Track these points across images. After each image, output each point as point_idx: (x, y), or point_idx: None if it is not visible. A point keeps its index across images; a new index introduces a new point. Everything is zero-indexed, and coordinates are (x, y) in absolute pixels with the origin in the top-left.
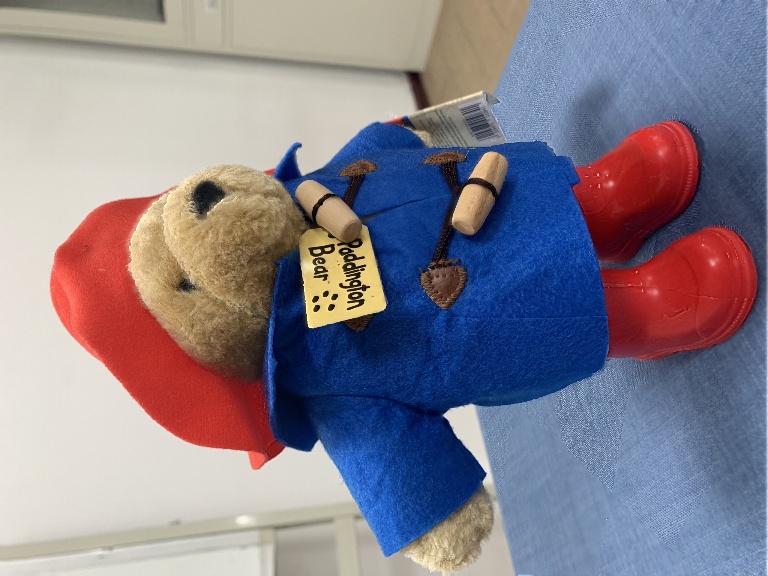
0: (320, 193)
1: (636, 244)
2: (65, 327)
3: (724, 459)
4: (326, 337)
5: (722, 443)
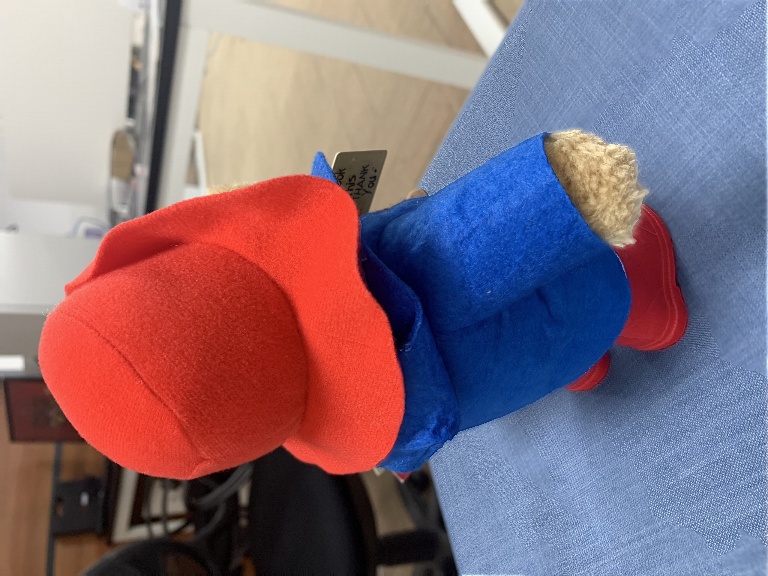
0: None
1: None
2: (64, 322)
3: (764, 215)
4: None
5: (749, 219)
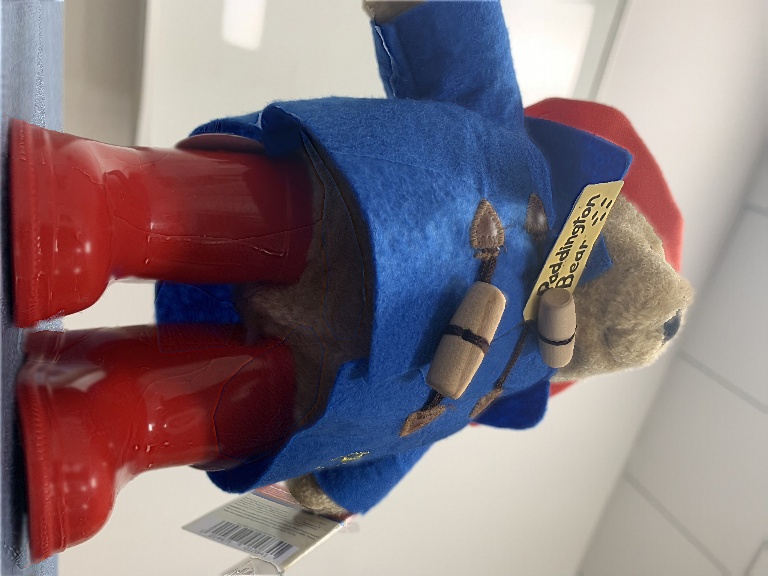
0: (571, 345)
1: (36, 349)
2: None
3: None
4: (550, 194)
5: None
